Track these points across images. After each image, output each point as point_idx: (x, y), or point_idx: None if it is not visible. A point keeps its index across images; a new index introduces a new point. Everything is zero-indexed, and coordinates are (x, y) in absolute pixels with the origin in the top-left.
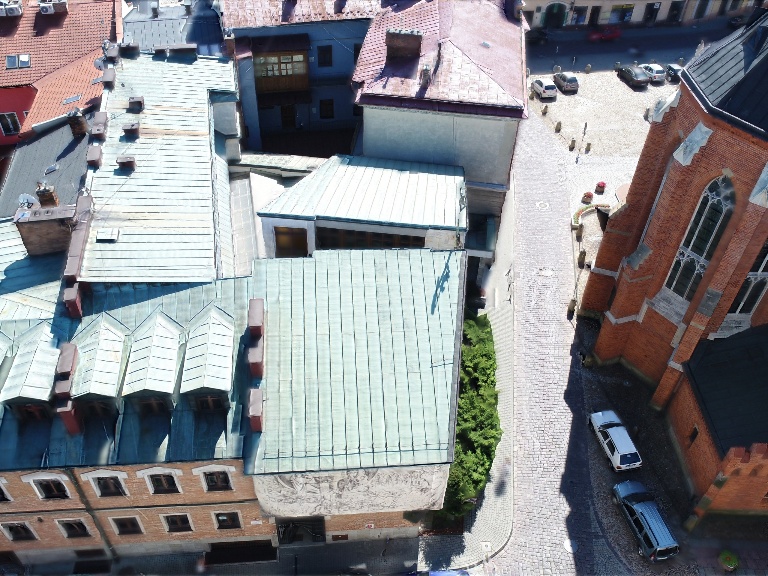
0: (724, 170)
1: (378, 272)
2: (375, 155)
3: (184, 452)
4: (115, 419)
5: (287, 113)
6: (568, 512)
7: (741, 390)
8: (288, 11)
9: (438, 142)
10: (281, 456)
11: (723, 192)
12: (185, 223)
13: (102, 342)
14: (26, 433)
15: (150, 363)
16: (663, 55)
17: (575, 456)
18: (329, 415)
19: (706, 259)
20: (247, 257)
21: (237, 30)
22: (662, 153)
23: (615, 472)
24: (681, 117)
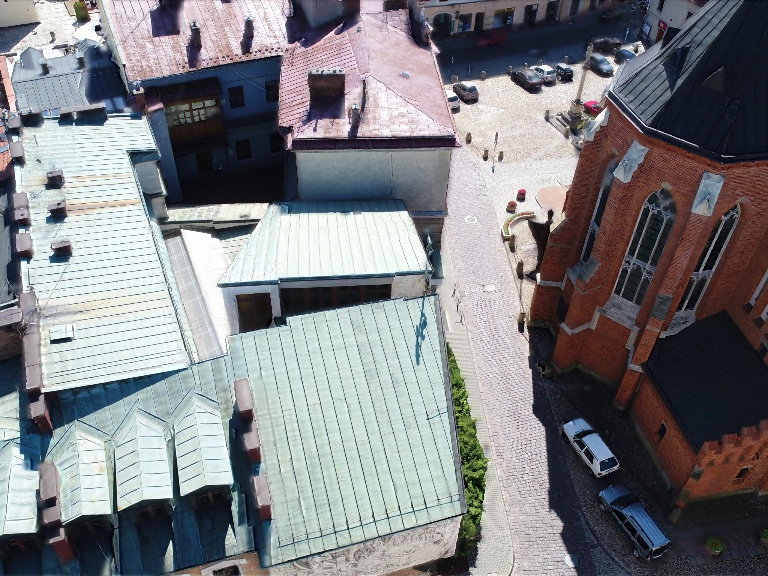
0: (663, 184)
1: (356, 330)
2: (312, 198)
3: (193, 556)
4: (111, 535)
5: (203, 158)
6: (562, 527)
7: (700, 383)
8: (194, 56)
9: (374, 178)
10: (296, 541)
11: (662, 203)
12: (141, 306)
13: (82, 455)
14: (12, 570)
15: (141, 469)
16: (548, 54)
17: (556, 469)
18: (336, 488)
19: (651, 265)
20: (198, 322)
21: (142, 81)
22: (597, 169)
23: (596, 478)
24: (613, 135)
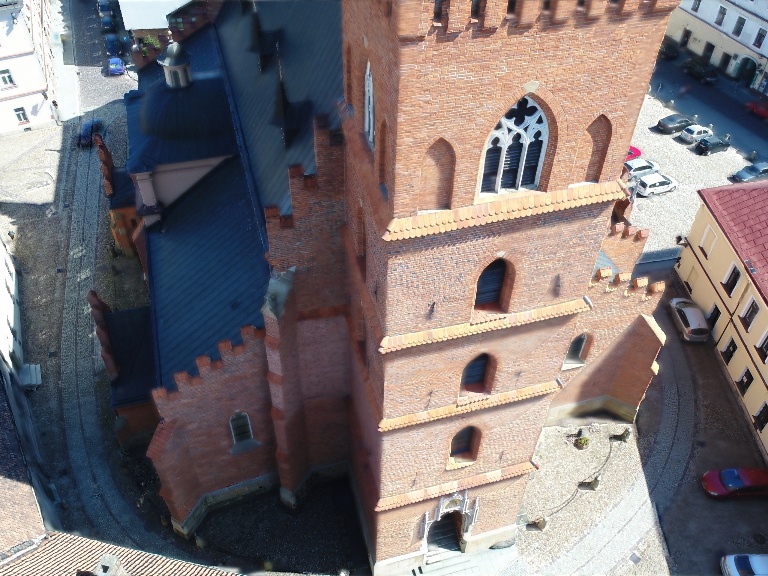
0: None
1: None
2: None
3: None
4: None
5: None
6: None
7: None
8: None
9: None
10: None
11: None
12: None
13: None
14: None
15: None
16: None
17: None
18: None
19: None
20: None
21: None
22: None
23: None
24: None
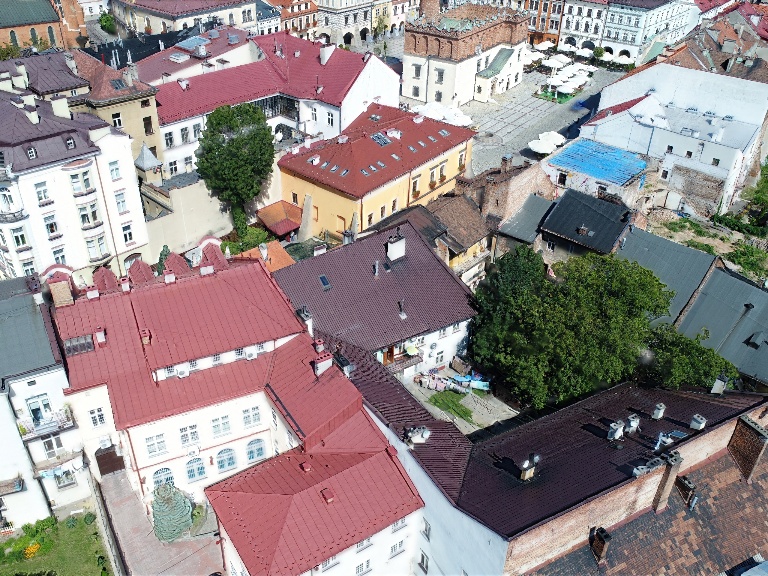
0: None
1: None
2: None
3: None
4: None
5: None
6: None
7: None
8: None
9: None
10: None
11: None
12: None
13: None
14: None
15: None
16: None
17: None
18: None
19: None
20: None
21: None
22: None
23: None
24: None
